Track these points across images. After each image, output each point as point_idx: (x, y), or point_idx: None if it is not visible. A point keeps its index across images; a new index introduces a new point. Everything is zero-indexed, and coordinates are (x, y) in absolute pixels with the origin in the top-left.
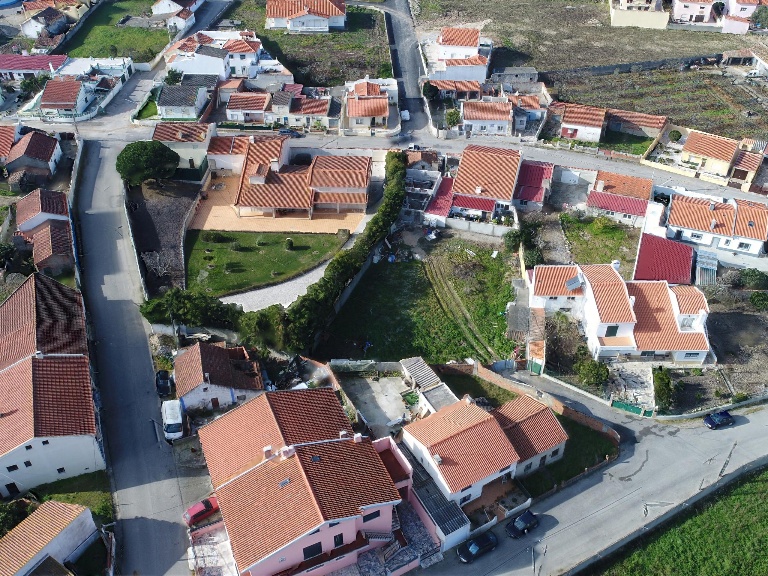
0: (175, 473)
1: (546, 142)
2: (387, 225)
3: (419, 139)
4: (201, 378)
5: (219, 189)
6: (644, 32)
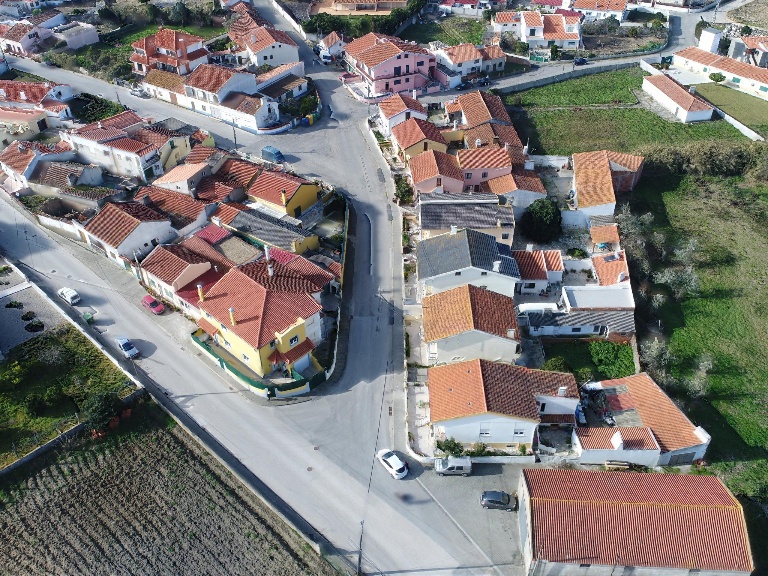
0: (331, 70)
1: None
2: (420, 5)
3: None
4: None
5: (322, 1)
6: None
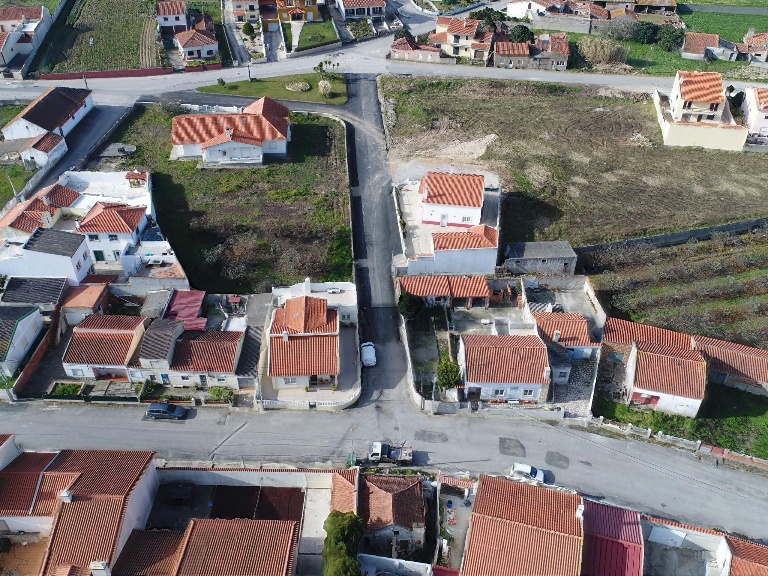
0: None
1: (607, 422)
2: None
3: (391, 416)
4: None
5: None
6: (713, 157)
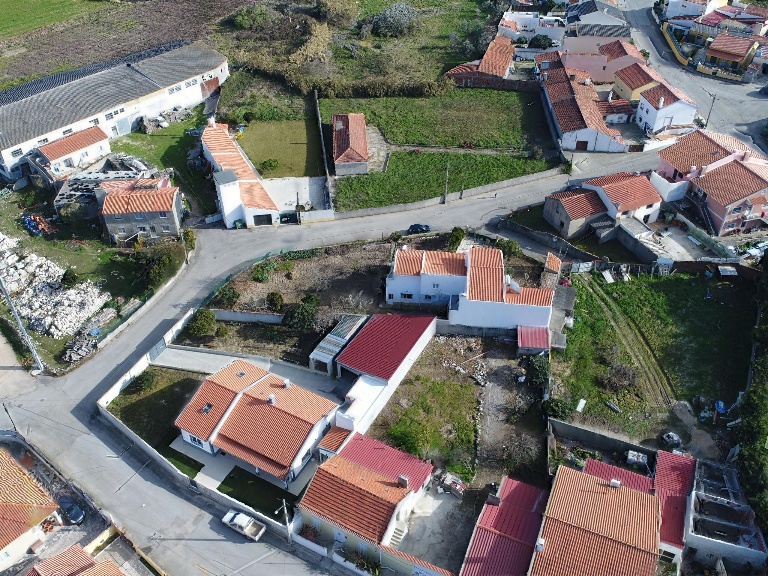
0: None
1: None
2: (746, 406)
3: None
4: None
5: None
6: None
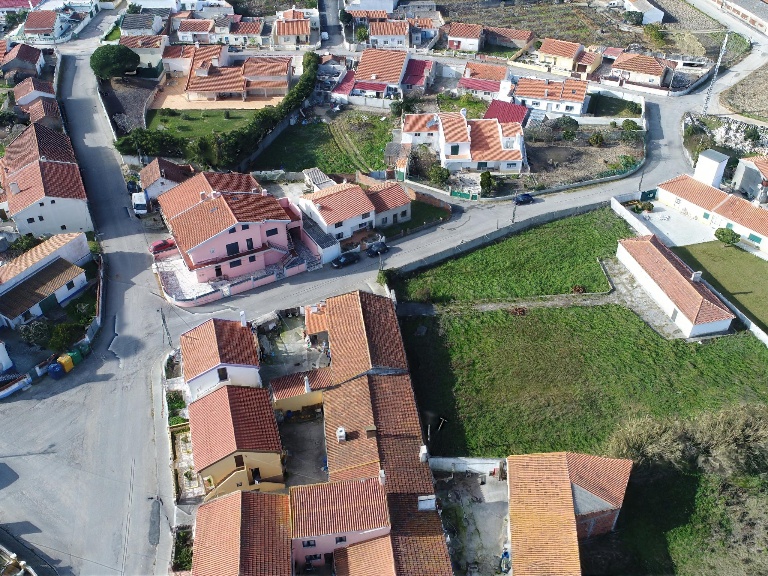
0: (143, 231)
1: (436, 51)
2: (301, 97)
3: (335, 52)
4: (159, 175)
5: (173, 85)
6: None
